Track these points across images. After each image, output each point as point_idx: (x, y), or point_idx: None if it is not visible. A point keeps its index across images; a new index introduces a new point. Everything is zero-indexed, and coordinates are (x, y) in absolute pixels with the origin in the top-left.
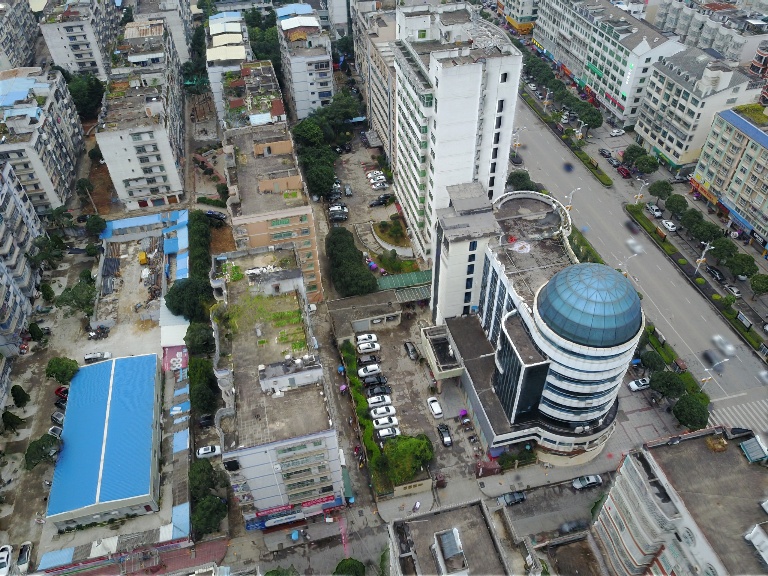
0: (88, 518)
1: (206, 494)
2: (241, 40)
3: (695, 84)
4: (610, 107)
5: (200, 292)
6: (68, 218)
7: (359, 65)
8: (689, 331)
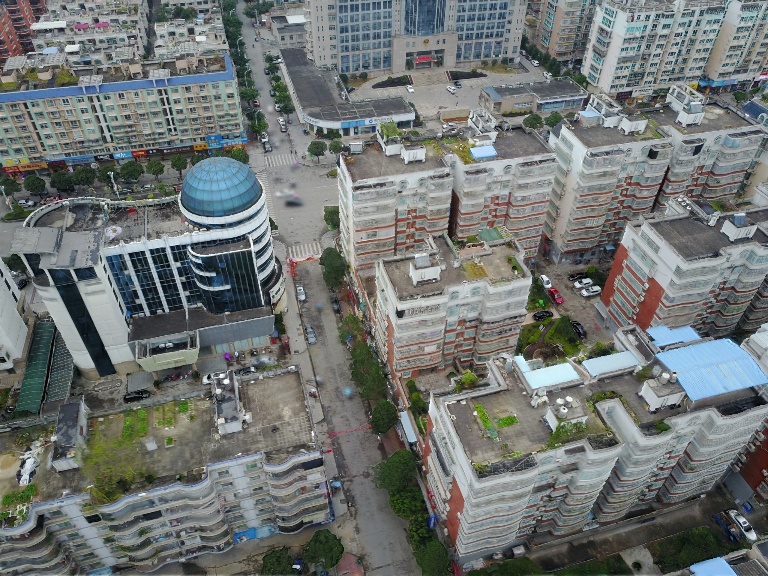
0: None
1: (293, 571)
2: None
3: None
4: None
5: None
6: None
7: None
8: None
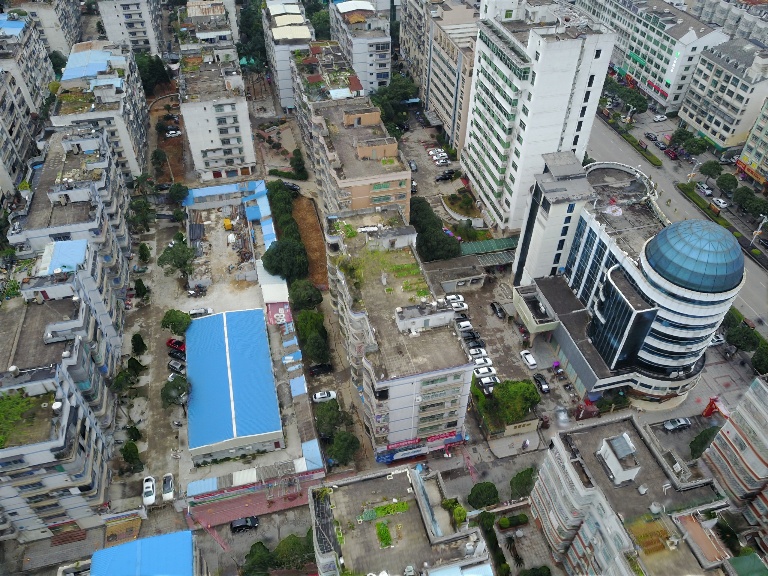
0: (223, 453)
1: (333, 431)
2: (303, 21)
3: (745, 71)
4: (652, 94)
5: (297, 253)
6: (150, 186)
7: (406, 50)
8: (751, 295)
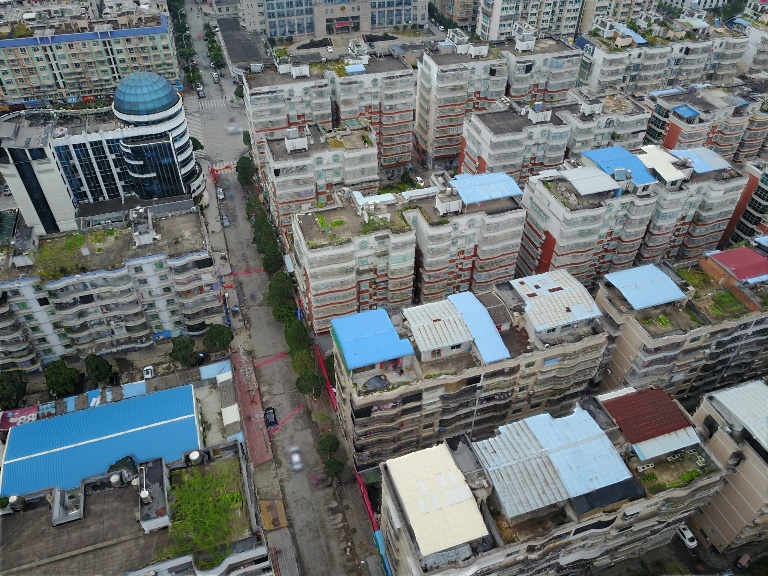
0: None
1: None
2: None
3: None
4: None
5: None
6: None
7: None
8: None
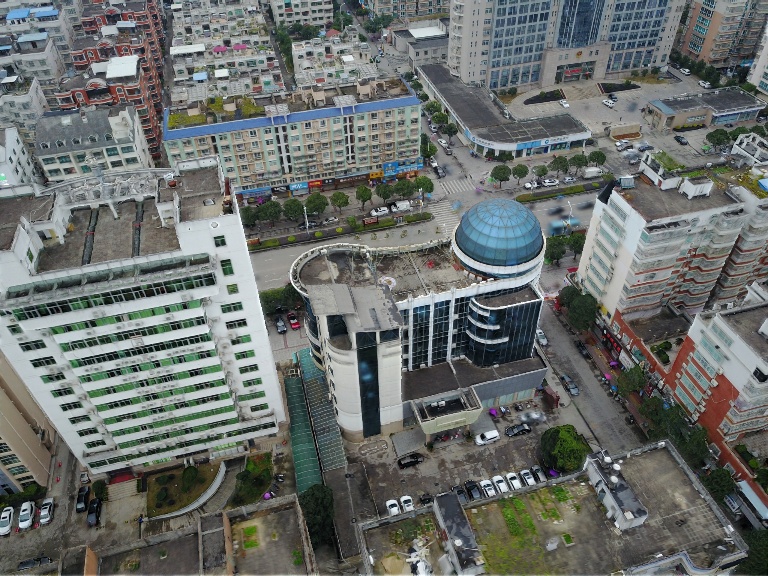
0: None
1: None
2: None
3: (113, 136)
4: None
5: None
6: None
7: None
8: None
